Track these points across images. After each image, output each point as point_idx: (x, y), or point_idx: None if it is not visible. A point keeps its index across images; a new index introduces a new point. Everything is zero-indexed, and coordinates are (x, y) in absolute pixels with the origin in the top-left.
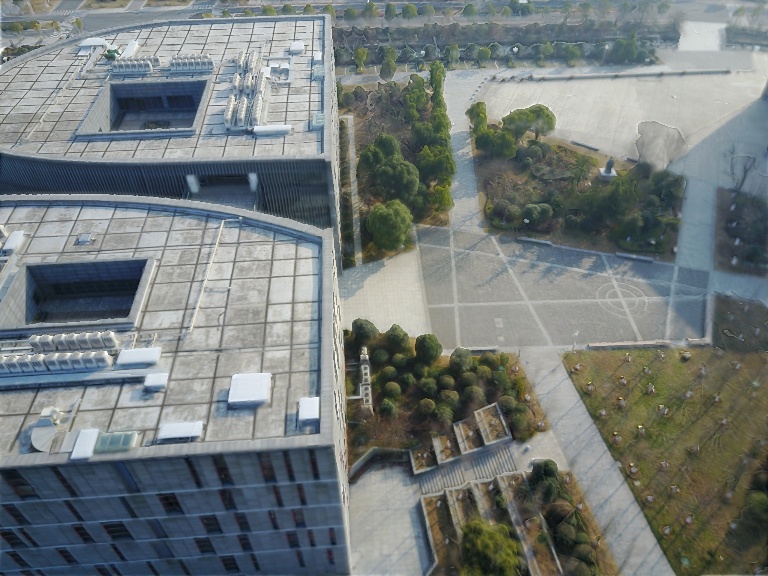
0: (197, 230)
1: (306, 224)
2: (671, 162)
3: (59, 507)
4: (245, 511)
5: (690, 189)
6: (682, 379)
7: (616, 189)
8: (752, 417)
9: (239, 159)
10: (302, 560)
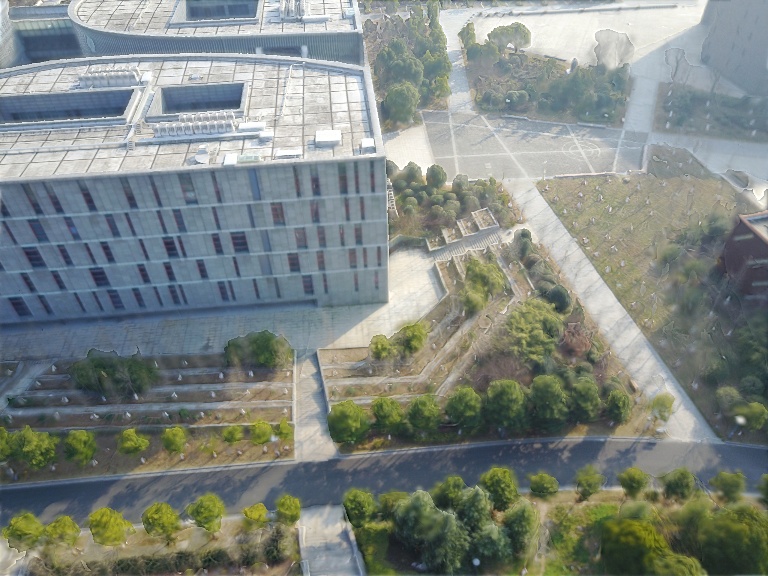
0: (273, 71)
1: (351, 64)
2: (622, 61)
3: (208, 214)
4: (324, 225)
5: (638, 83)
6: (623, 193)
7: (576, 73)
8: (672, 211)
9: (295, 33)
10: (357, 283)
